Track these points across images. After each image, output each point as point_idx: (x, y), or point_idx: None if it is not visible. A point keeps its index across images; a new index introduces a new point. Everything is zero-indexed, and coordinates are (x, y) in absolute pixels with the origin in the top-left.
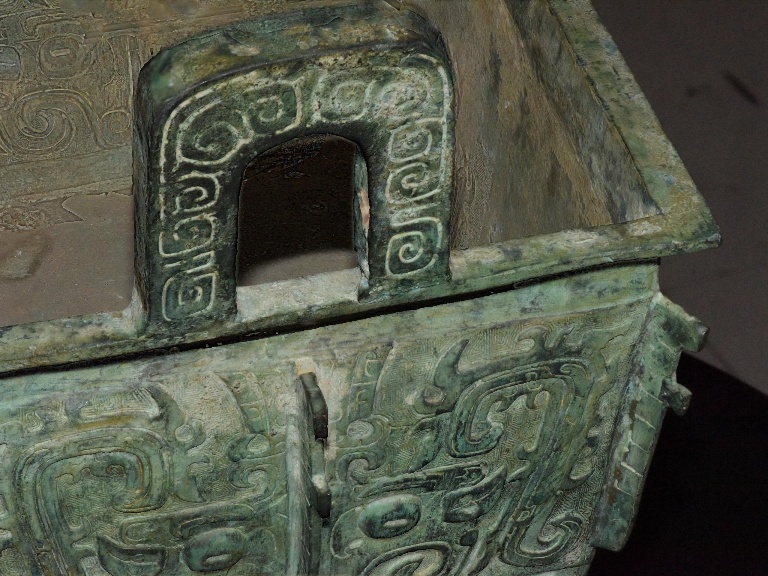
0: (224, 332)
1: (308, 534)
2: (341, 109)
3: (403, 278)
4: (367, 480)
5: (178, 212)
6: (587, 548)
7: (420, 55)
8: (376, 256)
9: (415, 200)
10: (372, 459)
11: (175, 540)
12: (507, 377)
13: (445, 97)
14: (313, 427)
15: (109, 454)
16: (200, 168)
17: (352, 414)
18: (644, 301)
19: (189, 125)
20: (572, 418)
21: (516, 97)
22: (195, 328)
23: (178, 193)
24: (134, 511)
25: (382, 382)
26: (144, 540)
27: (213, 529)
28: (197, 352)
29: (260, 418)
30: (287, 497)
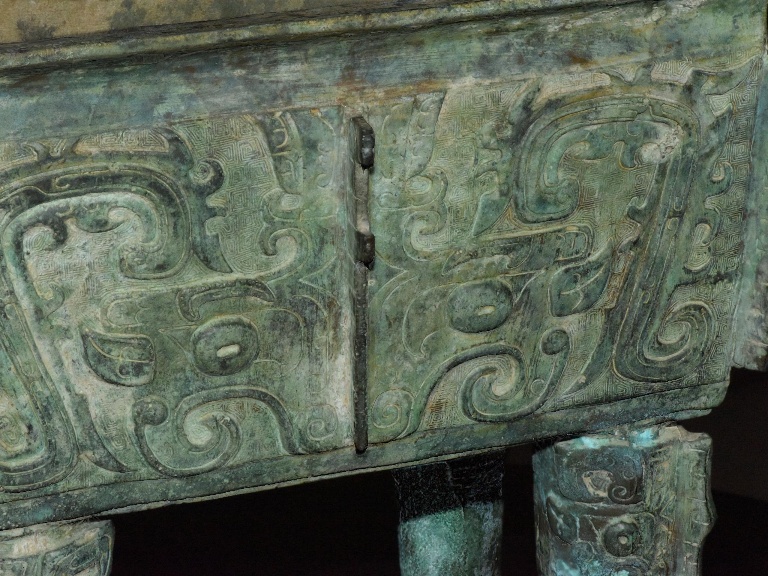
0: None
1: None
2: None
3: None
4: None
5: None
6: None
7: None
8: None
9: None
10: None
11: None
12: None
13: None
14: None
15: None
16: None
17: None
18: None
19: None
20: None
21: (106, 27)
22: None
23: None
24: None
25: None
26: None
27: None
28: None
29: None
30: None
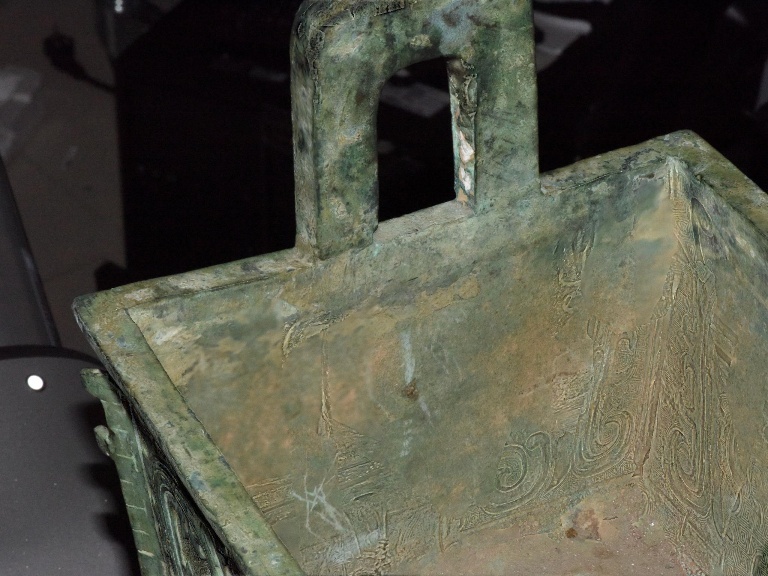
0: None
1: None
2: None
3: None
4: None
5: None
6: None
7: None
8: None
9: None
10: None
11: None
12: None
13: None
14: None
15: None
16: None
17: None
18: None
19: None
20: None
21: None
22: None
23: None
24: None
25: None
26: None
27: None
28: None
29: None
30: None
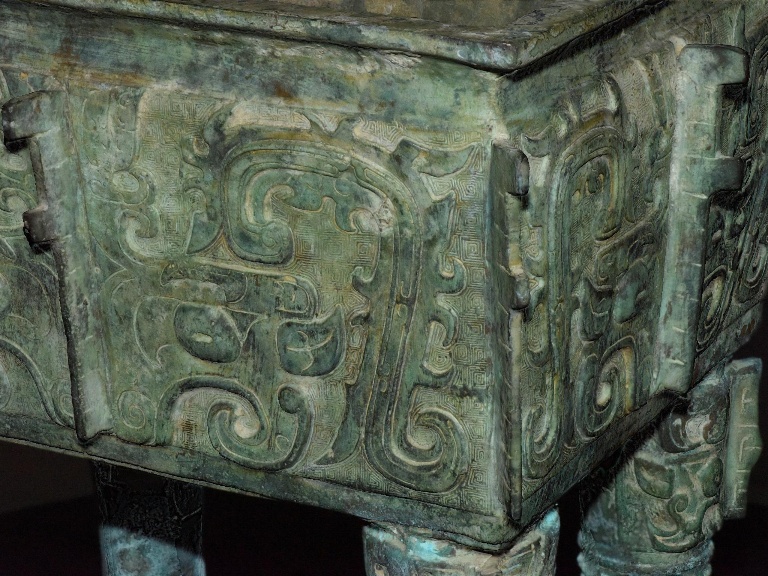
0: None
1: (700, 240)
2: None
3: None
4: None
5: None
6: (767, 275)
7: None
8: None
9: None
10: None
11: (618, 278)
12: (767, 44)
13: None
14: (743, 69)
15: (598, 160)
16: None
17: None
18: None
19: None
20: None
21: None
22: None
23: None
24: (607, 236)
25: None
26: (606, 279)
27: (635, 260)
28: (617, 40)
29: (663, 107)
30: None
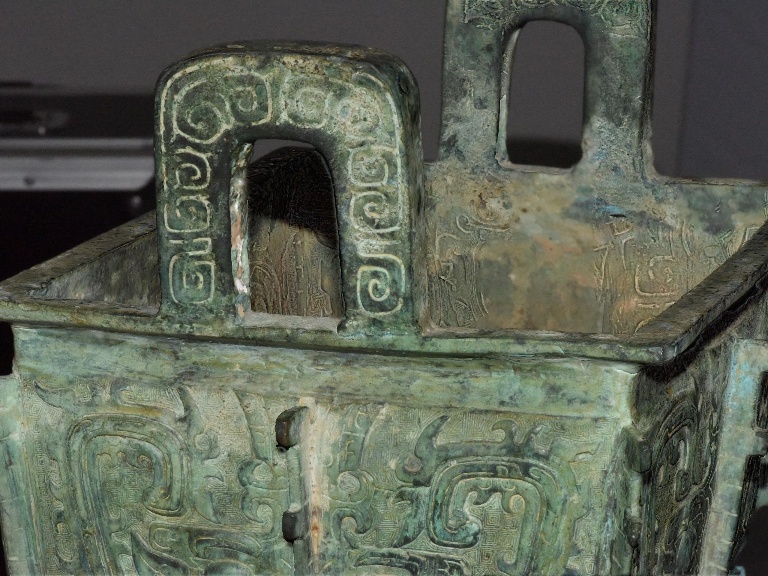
0: (226, 332)
1: None
2: (305, 114)
3: (375, 317)
4: (357, 544)
5: (179, 187)
6: None
7: (369, 76)
8: (347, 284)
9: (378, 232)
10: (359, 519)
11: (195, 559)
12: (479, 464)
13: (396, 128)
14: None
15: (140, 443)
16: (193, 145)
17: (341, 463)
18: (610, 420)
19: (182, 98)
20: (547, 536)
21: None
22: (200, 319)
23: (177, 167)
24: (159, 512)
25: (371, 439)
26: (169, 550)
27: (228, 559)
28: (226, 370)
29: (265, 445)
30: (291, 544)
